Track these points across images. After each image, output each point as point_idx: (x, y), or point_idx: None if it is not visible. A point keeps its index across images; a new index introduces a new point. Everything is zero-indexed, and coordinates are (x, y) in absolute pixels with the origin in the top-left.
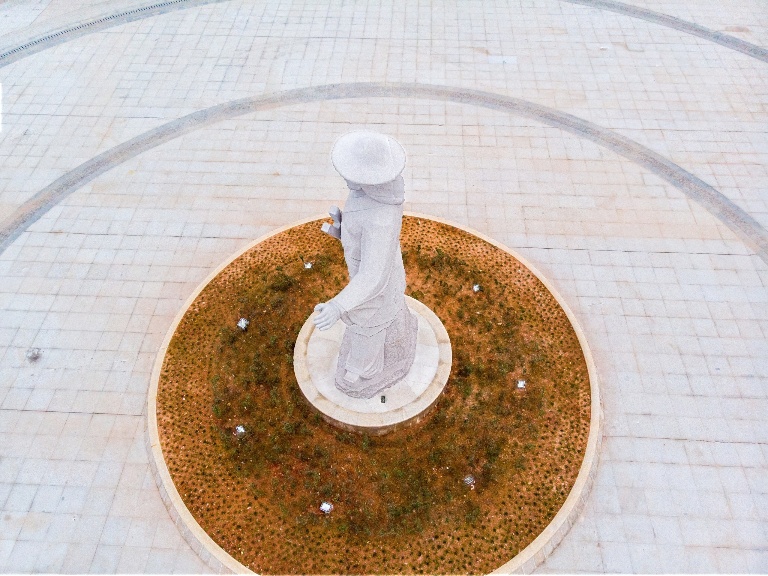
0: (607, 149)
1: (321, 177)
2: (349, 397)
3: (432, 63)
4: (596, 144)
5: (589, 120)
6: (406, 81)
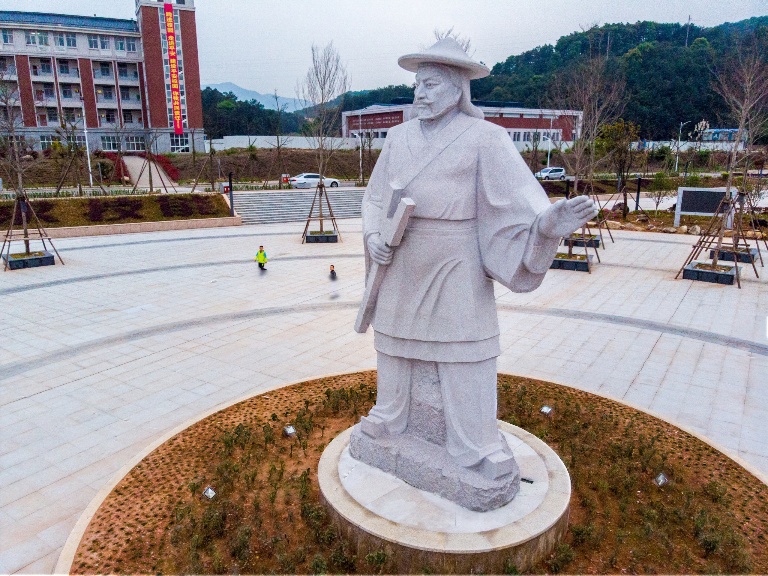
0: (314, 312)
1: (63, 446)
2: (506, 507)
3: (63, 332)
4: (302, 313)
5: (273, 307)
6: (52, 349)
